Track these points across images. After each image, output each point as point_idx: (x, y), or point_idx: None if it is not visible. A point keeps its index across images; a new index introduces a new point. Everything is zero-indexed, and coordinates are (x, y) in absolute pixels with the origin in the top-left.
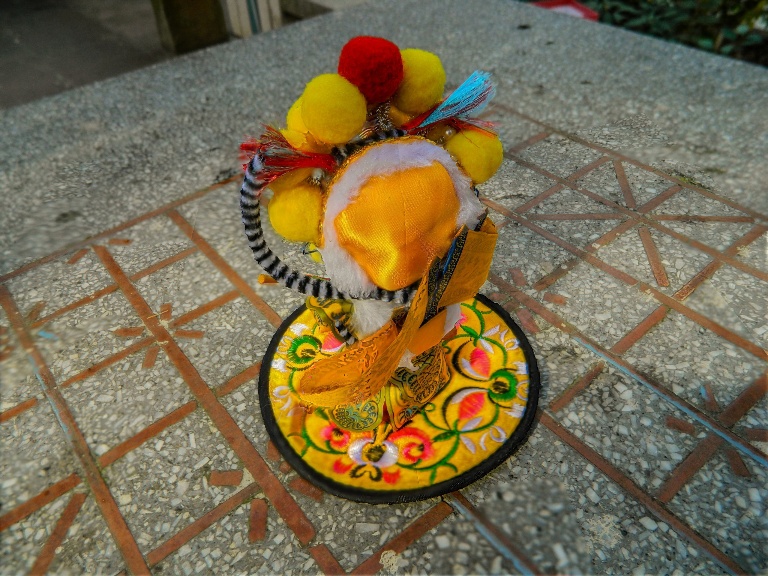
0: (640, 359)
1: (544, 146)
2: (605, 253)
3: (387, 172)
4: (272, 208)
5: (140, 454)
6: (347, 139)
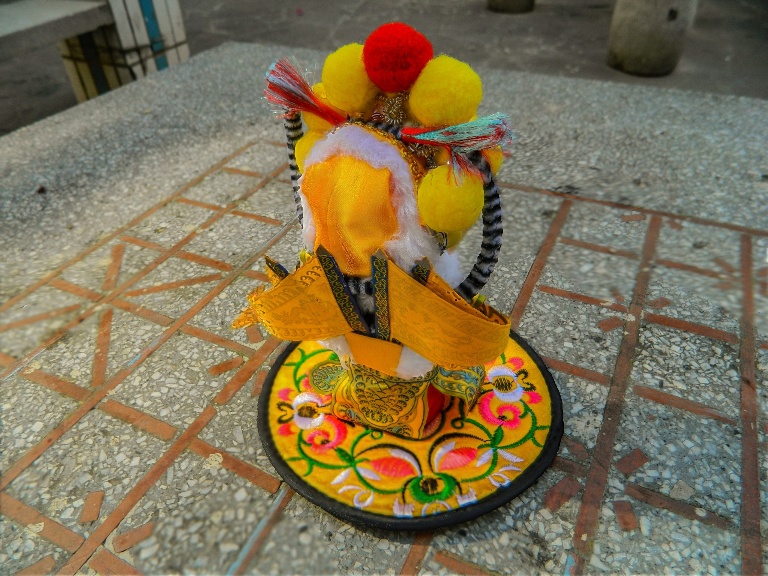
0: None
1: None
2: None
3: (345, 151)
4: None
5: (258, 285)
6: (343, 107)
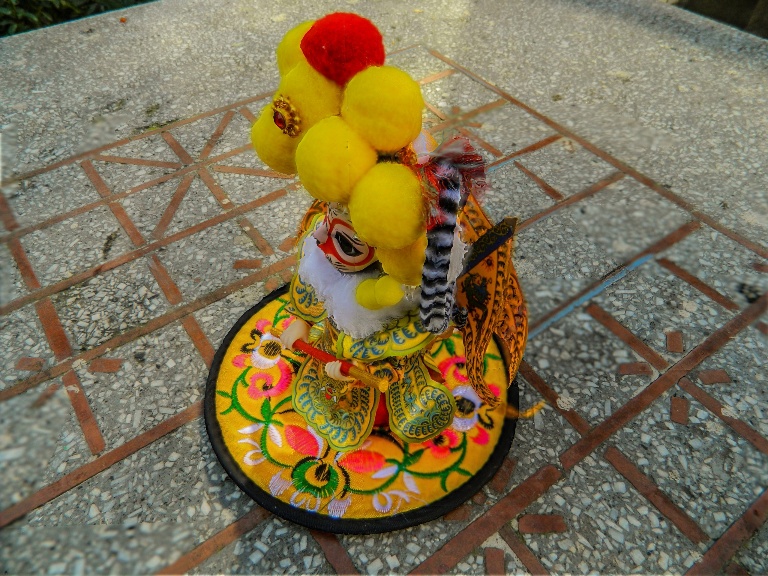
0: None
1: (23, 201)
2: (239, 198)
3: None
4: None
5: None
6: None
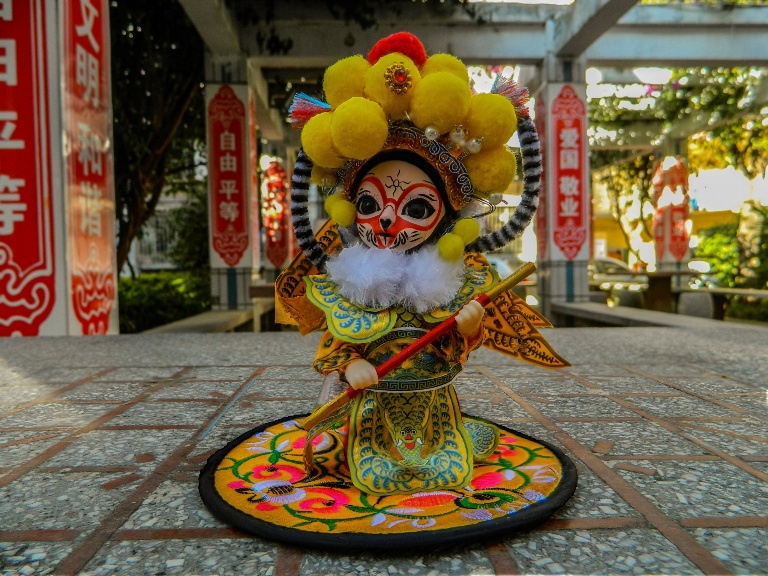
0: (193, 421)
1: None
2: (6, 463)
3: None
4: None
5: (765, 510)
6: None
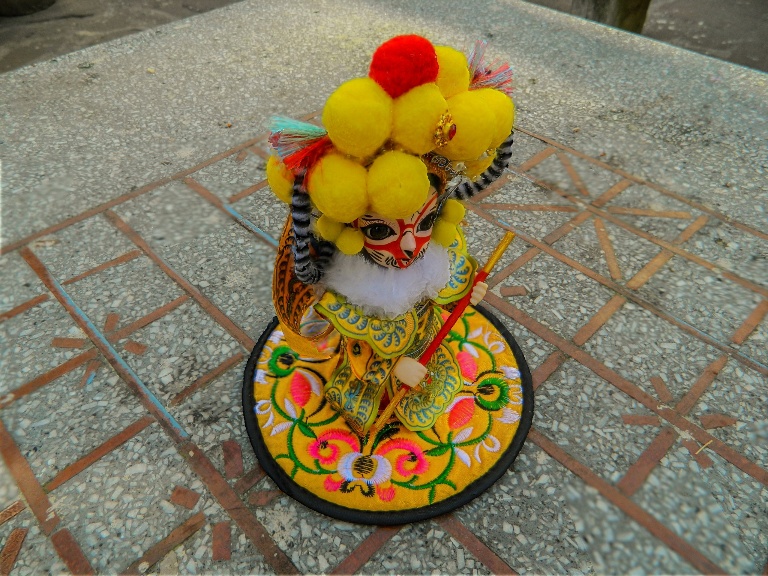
0: (129, 411)
1: None
2: None
3: None
4: None
5: (594, 304)
6: None
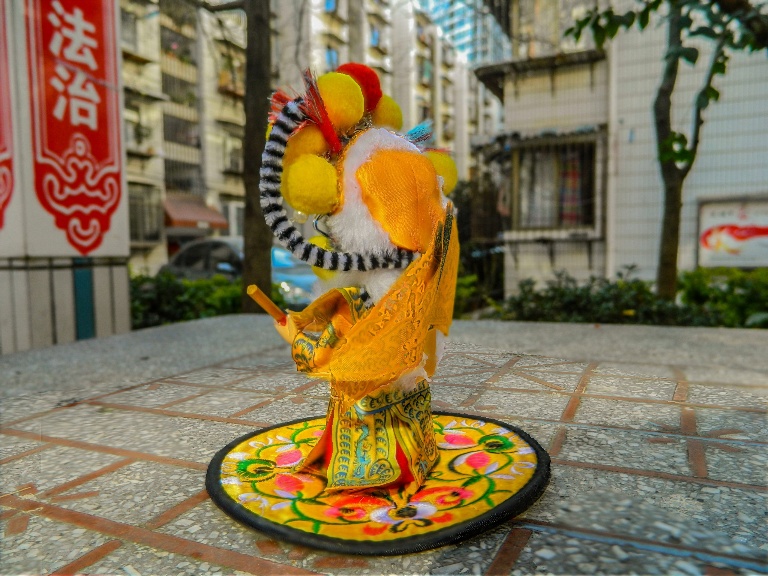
0: (589, 419)
1: None
2: (500, 384)
3: (390, 144)
4: (293, 165)
5: None
6: (354, 117)
